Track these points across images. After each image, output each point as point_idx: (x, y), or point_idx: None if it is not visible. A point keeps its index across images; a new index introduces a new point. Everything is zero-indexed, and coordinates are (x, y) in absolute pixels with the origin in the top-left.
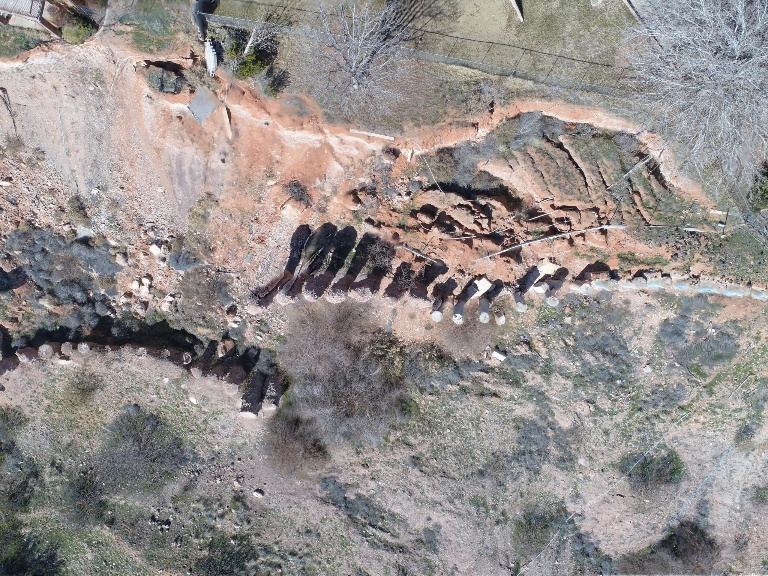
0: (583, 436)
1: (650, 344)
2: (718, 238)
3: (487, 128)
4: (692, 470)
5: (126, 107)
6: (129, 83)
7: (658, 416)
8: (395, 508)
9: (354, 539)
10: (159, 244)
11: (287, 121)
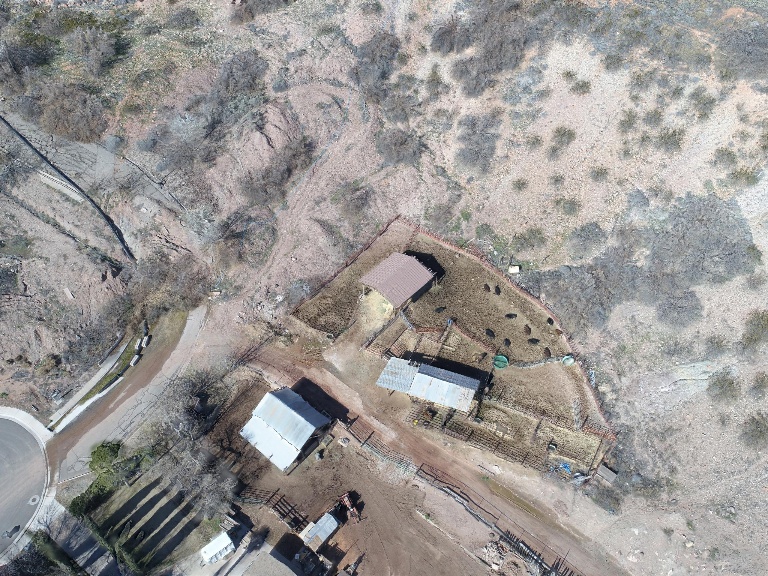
0: (348, 4)
1: None
2: None
3: None
4: (385, 9)
5: None
6: None
7: None
8: (274, 29)
9: (254, 38)
10: None
11: None
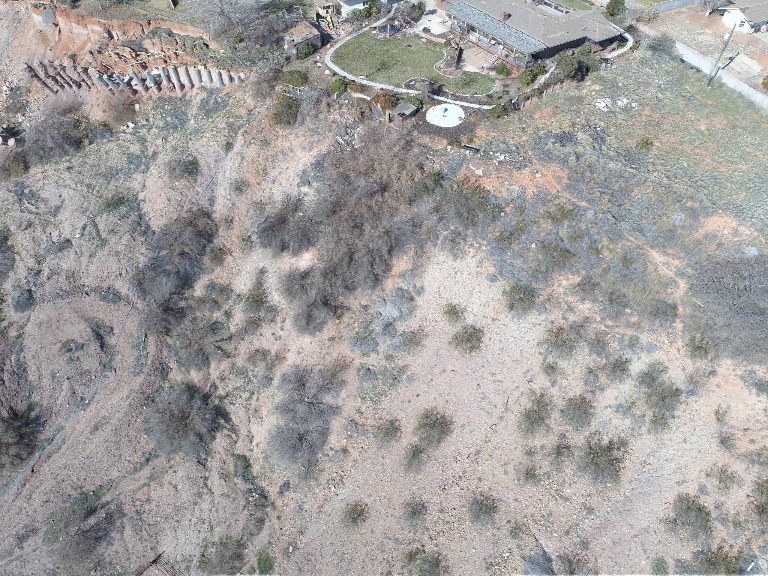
0: None
1: (196, 111)
2: (220, 57)
3: (148, 30)
4: (204, 170)
5: (24, 32)
6: (30, 23)
7: (191, 139)
8: (46, 194)
9: None
10: (8, 87)
11: (73, 18)
